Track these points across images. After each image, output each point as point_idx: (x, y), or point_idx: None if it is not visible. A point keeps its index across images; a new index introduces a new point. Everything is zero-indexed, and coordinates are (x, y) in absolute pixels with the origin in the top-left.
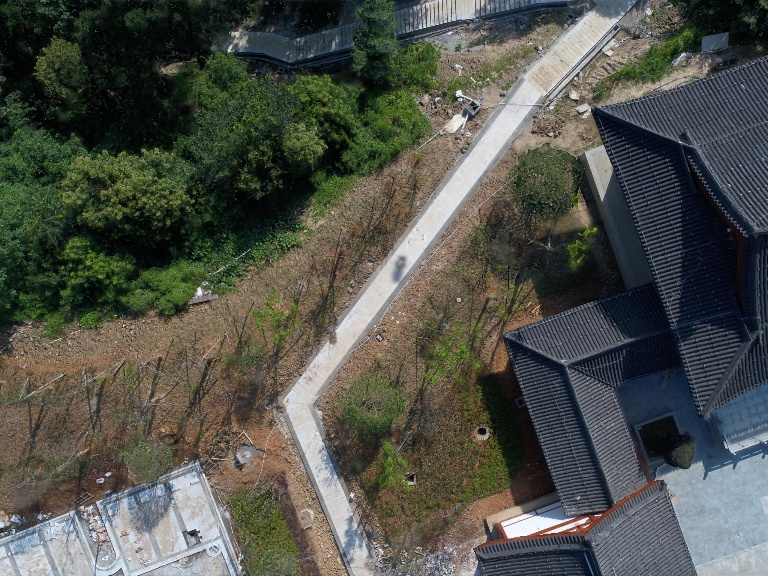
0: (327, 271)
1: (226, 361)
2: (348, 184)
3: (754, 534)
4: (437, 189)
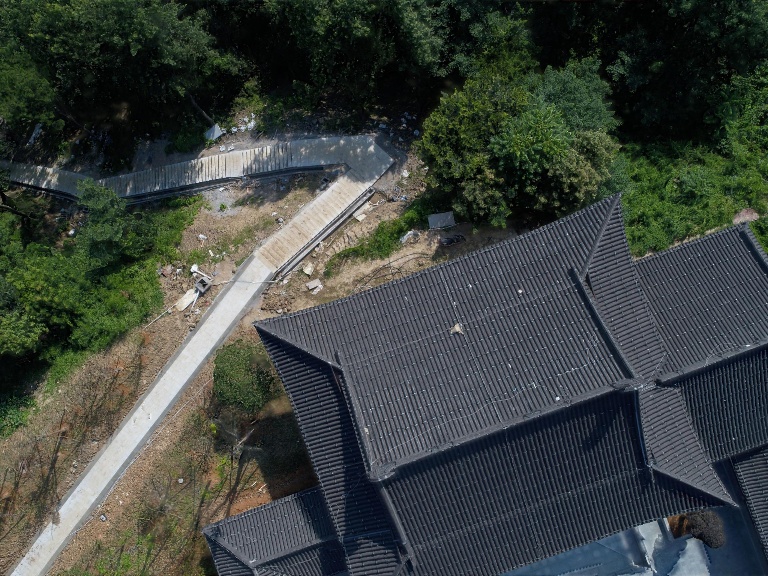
0: (49, 452)
1: None
2: (79, 361)
3: None
4: (164, 367)
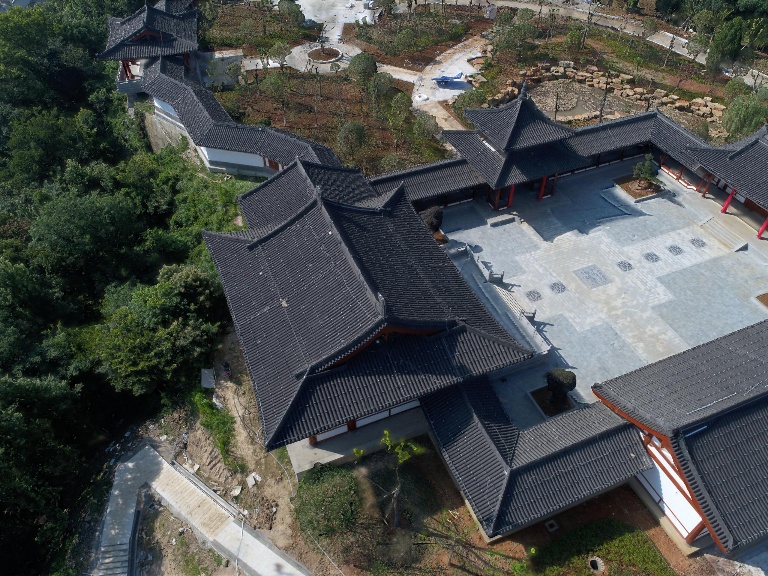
0: None
1: None
2: None
3: (609, 334)
4: None
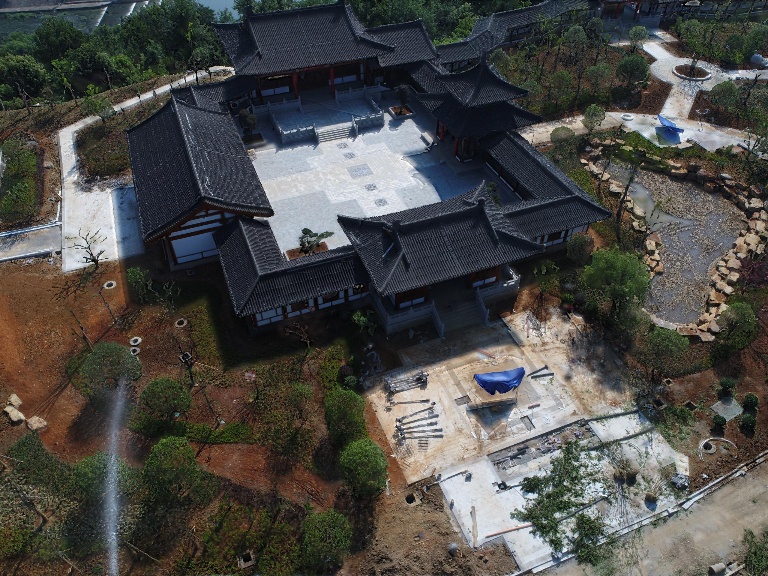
0: None
1: (37, 115)
2: None
3: None
4: None
